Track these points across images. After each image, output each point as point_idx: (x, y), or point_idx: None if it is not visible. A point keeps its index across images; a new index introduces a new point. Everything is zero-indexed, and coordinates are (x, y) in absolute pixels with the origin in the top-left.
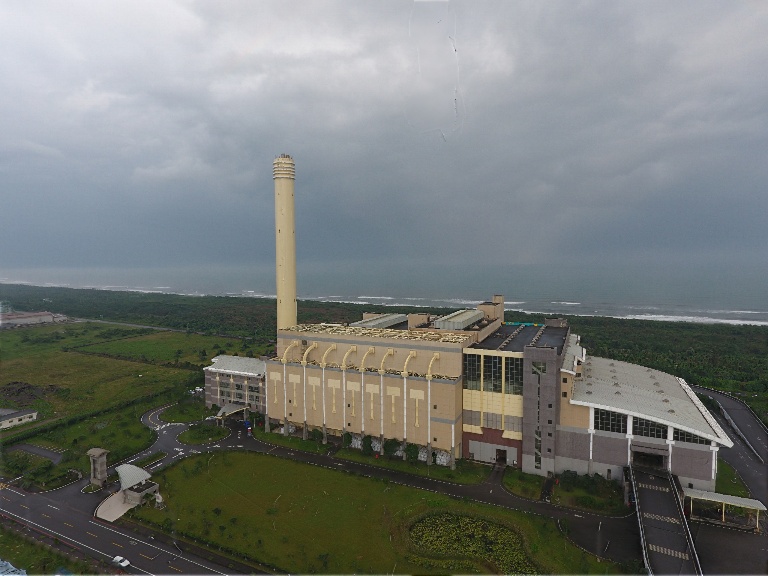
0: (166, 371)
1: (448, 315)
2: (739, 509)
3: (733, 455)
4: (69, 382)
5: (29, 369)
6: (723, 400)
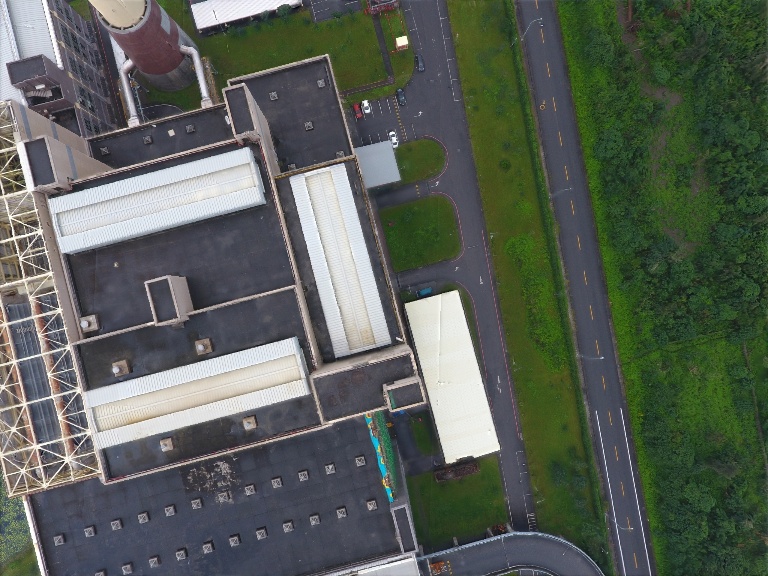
0: None
1: (173, 373)
2: None
3: None
4: None
5: None
6: None
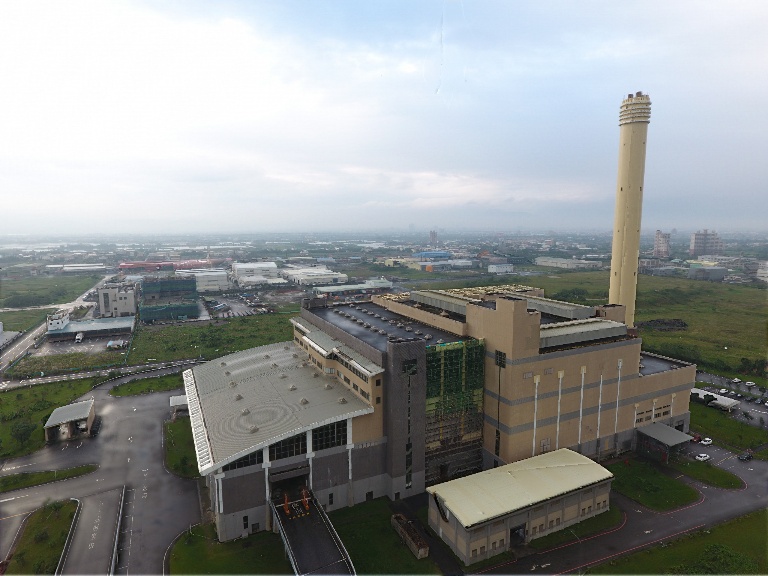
0: (749, 355)
1: None
2: (180, 421)
3: (154, 487)
4: (698, 332)
5: (763, 326)
6: None
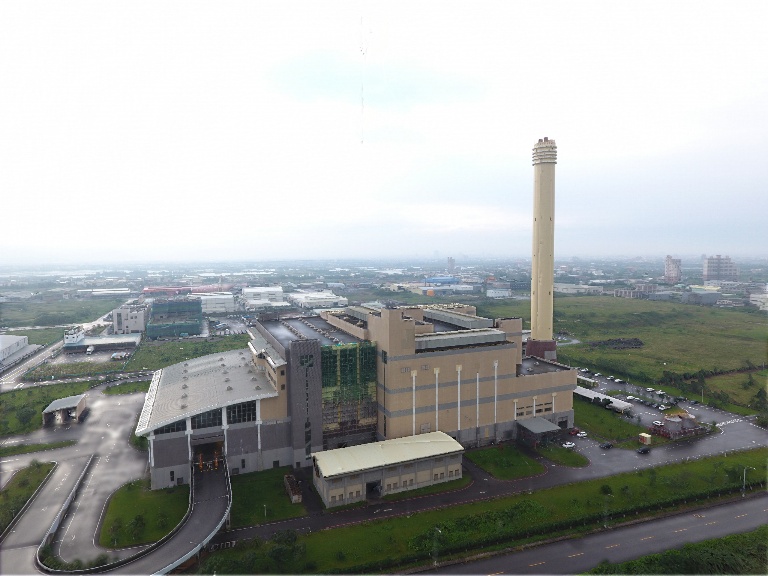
0: None
1: None
2: None
3: (116, 455)
4: None
5: (718, 346)
6: (15, 567)
